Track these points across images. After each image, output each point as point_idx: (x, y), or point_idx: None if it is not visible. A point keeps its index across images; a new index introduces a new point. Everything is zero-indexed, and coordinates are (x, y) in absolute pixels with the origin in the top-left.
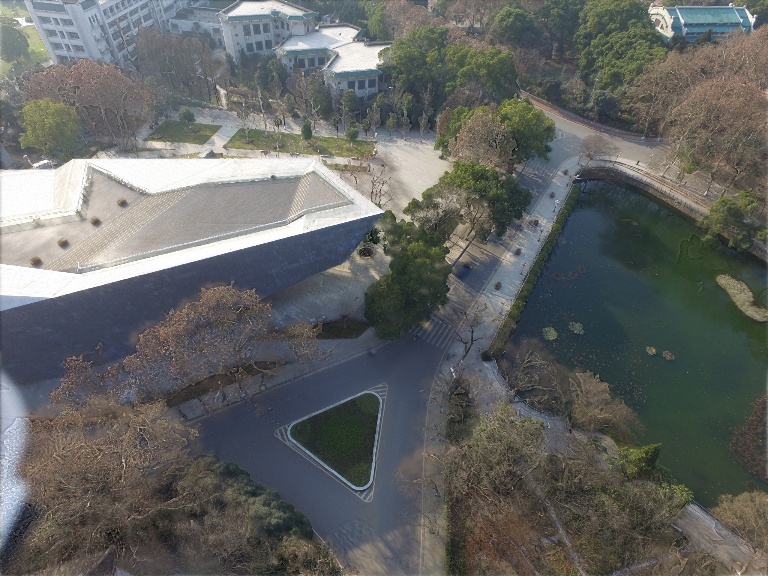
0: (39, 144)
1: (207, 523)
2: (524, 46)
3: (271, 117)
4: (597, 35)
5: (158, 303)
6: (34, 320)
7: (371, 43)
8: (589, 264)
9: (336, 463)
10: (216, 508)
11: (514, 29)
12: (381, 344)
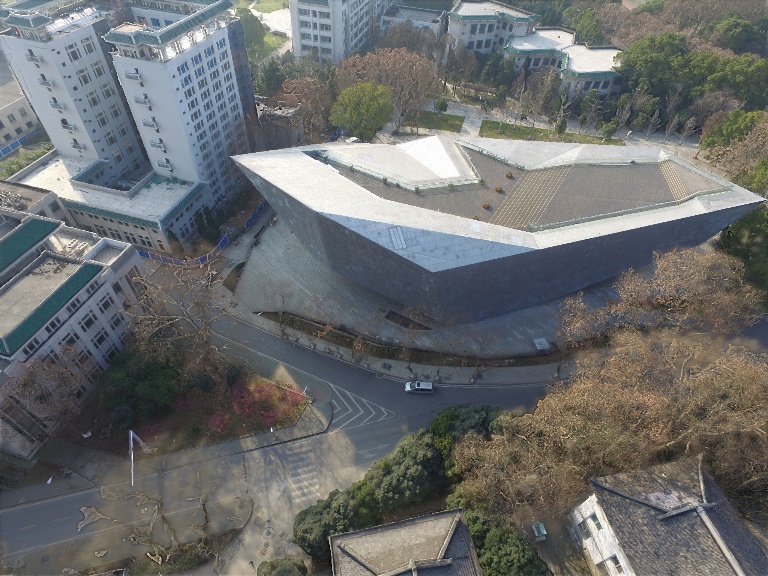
0: (353, 122)
1: (724, 451)
2: None
3: (505, 111)
4: None
5: (579, 264)
6: (511, 268)
7: (593, 46)
8: None
9: None
10: (734, 438)
11: (739, 39)
12: None
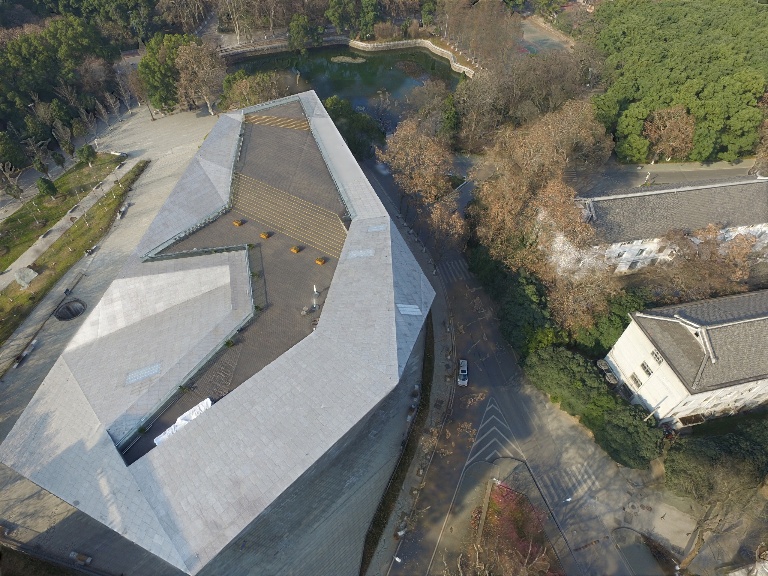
0: None
1: None
2: (18, 25)
3: None
4: None
5: None
6: None
7: None
8: None
9: (453, 187)
10: None
11: None
12: (367, 169)
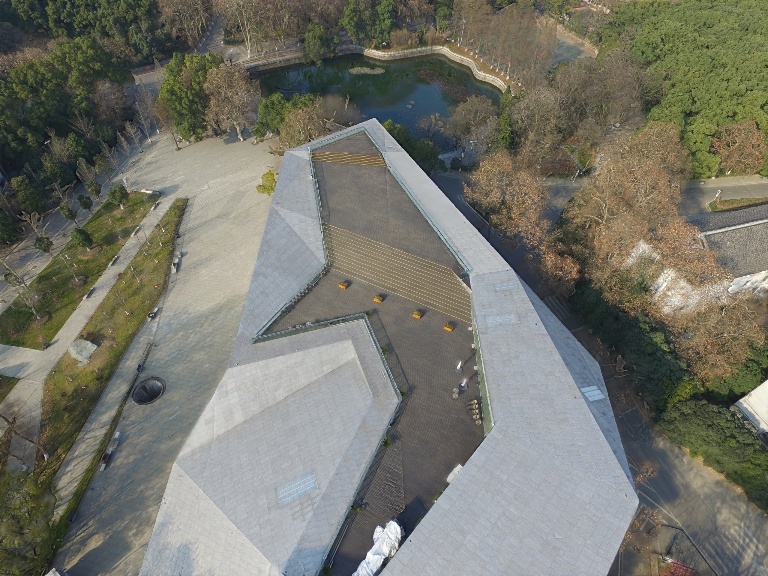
0: None
1: None
2: (9, 46)
3: None
4: (39, 3)
5: None
6: None
7: None
8: (337, 109)
9: None
10: None
11: None
12: None
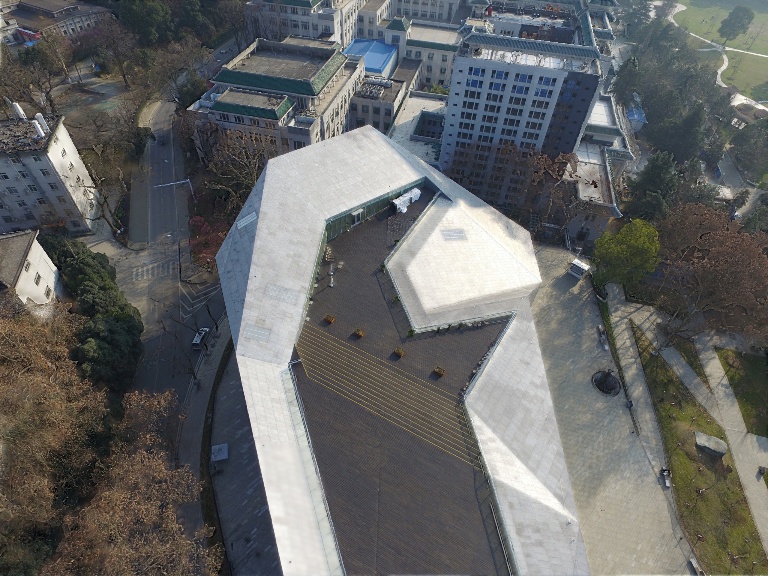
0: None
1: None
2: None
3: None
4: None
5: None
6: None
7: None
8: None
9: None
10: None
11: None
12: None
